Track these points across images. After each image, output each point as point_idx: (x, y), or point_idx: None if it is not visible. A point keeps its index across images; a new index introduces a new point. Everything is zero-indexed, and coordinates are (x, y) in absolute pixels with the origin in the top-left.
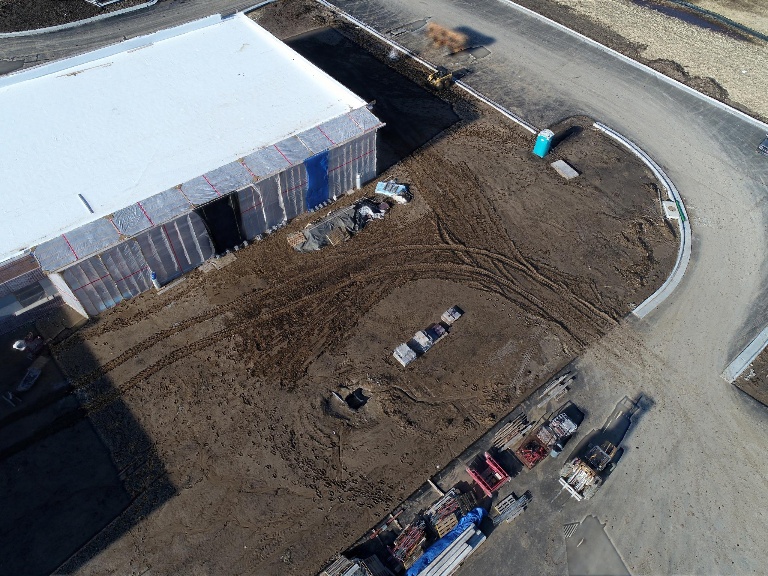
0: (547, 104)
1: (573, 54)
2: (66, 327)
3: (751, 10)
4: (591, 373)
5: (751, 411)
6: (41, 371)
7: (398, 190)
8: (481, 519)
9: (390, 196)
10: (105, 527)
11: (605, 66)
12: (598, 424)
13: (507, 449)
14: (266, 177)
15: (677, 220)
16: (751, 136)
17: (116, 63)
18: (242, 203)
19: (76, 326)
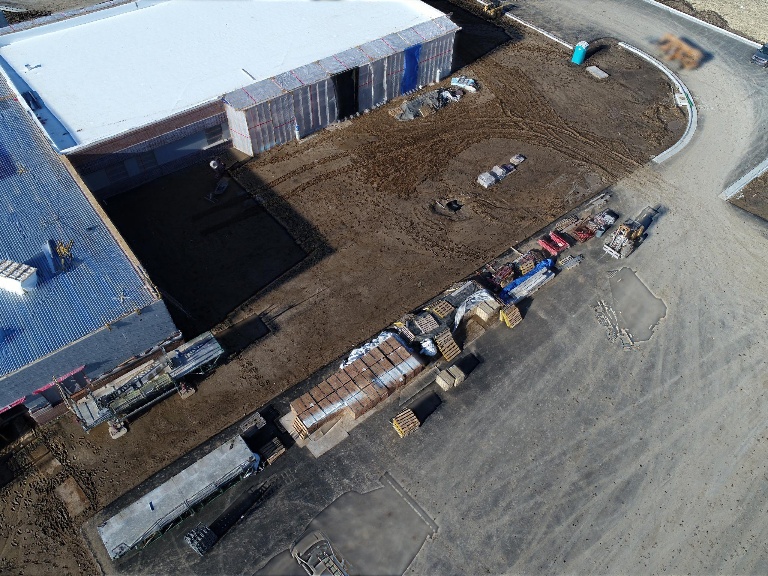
0: (581, 29)
1: None
2: (237, 161)
3: None
4: (623, 193)
5: (740, 215)
6: None
7: (469, 83)
8: (550, 266)
9: (463, 87)
10: (293, 267)
11: (627, 3)
12: (629, 221)
13: (565, 233)
14: (378, 59)
15: (686, 106)
16: (746, 52)
17: None
18: (360, 78)
19: (244, 160)
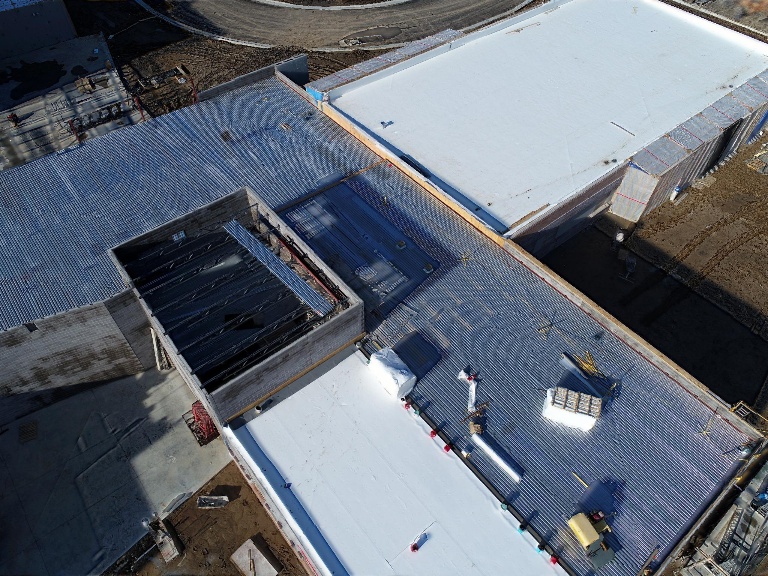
0: None
1: None
2: (623, 228)
3: None
4: None
5: None
6: (635, 258)
7: None
8: None
9: None
10: None
11: None
12: None
13: None
14: (757, 108)
15: None
16: None
17: (543, 22)
18: None
19: (630, 228)
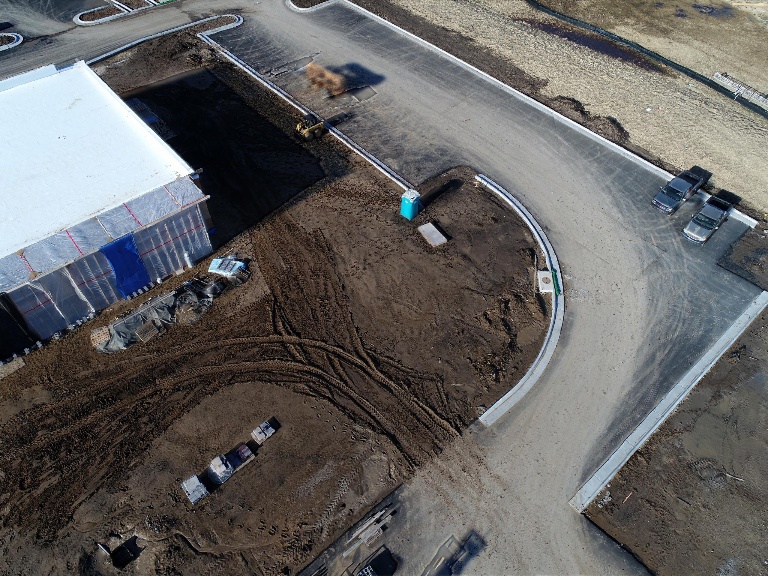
0: (427, 154)
1: (466, 93)
2: None
3: (668, 36)
4: (416, 505)
5: (599, 551)
6: None
7: (234, 268)
8: None
9: (225, 276)
10: None
11: (499, 106)
12: None
13: None
14: (47, 272)
15: (551, 294)
16: (648, 186)
17: None
18: (20, 303)
19: None
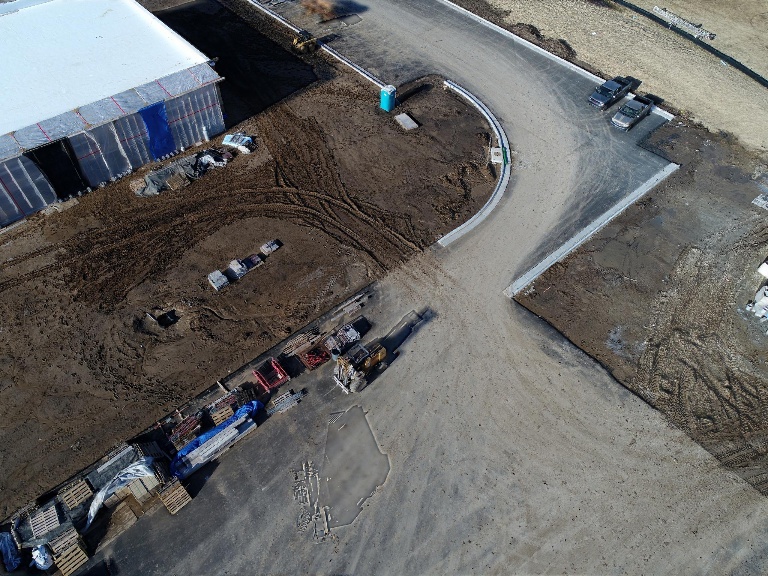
0: (405, 65)
1: (440, 20)
2: None
3: None
4: (387, 292)
5: (522, 319)
6: None
7: (243, 141)
8: (256, 410)
9: (236, 147)
10: None
11: (467, 30)
12: (382, 333)
13: (295, 355)
14: (99, 125)
15: (501, 164)
16: (587, 90)
17: None
18: (77, 149)
19: None
